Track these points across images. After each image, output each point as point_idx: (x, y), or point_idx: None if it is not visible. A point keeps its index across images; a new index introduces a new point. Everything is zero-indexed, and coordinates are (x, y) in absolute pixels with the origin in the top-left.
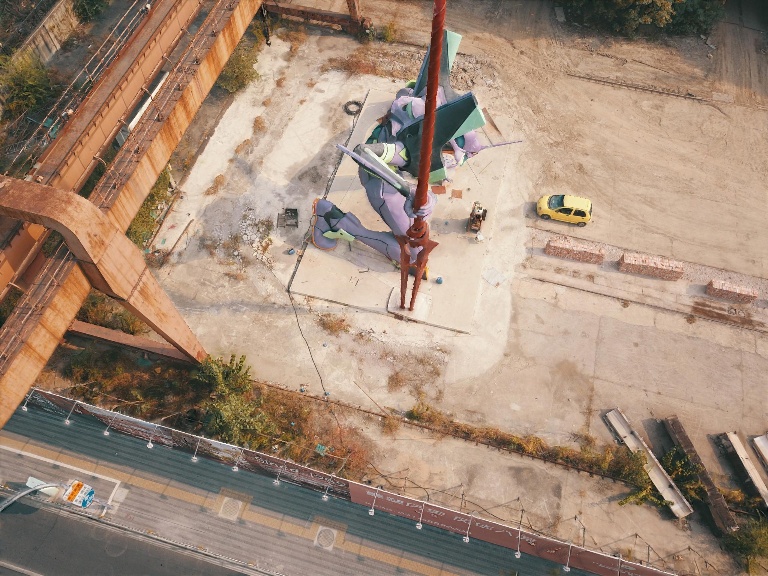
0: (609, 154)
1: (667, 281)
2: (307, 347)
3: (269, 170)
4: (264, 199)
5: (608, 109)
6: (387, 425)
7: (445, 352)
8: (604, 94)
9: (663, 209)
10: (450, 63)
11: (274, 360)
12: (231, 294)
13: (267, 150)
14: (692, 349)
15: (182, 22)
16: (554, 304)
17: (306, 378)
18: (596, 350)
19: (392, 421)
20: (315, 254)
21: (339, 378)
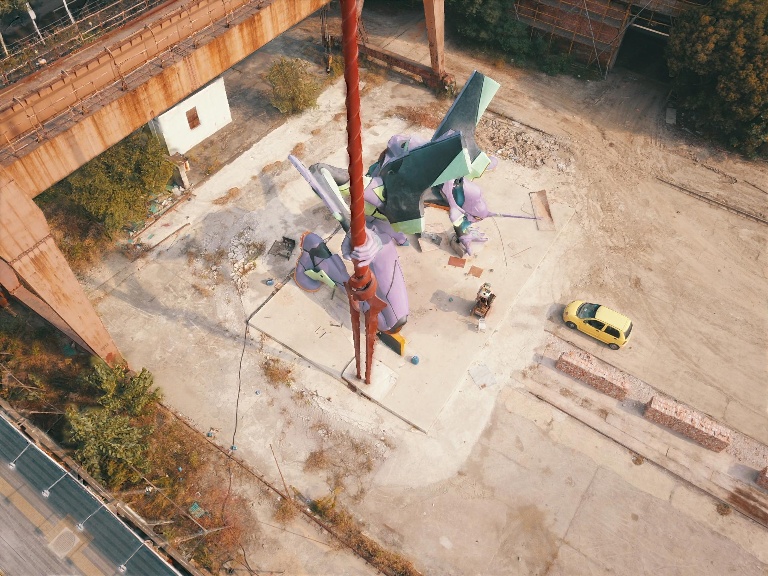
0: (678, 276)
1: (705, 449)
2: (238, 388)
3: (287, 196)
4: (268, 222)
5: (695, 226)
6: (282, 509)
7: (388, 445)
8: (695, 209)
9: (729, 358)
10: (479, 112)
11: (197, 391)
12: (188, 308)
13: (294, 176)
14: (713, 549)
15: (215, 15)
16: (545, 431)
17: (220, 422)
18: (578, 506)
19: (290, 506)
20: (292, 292)
21: (256, 435)
